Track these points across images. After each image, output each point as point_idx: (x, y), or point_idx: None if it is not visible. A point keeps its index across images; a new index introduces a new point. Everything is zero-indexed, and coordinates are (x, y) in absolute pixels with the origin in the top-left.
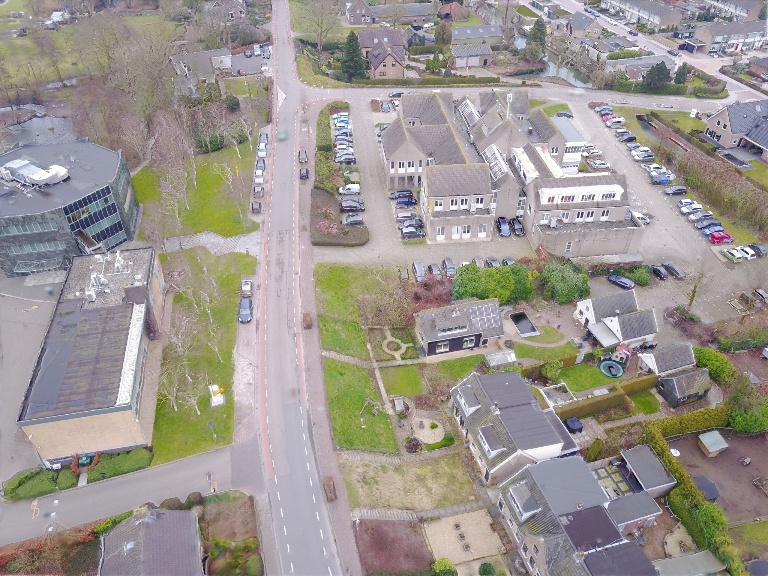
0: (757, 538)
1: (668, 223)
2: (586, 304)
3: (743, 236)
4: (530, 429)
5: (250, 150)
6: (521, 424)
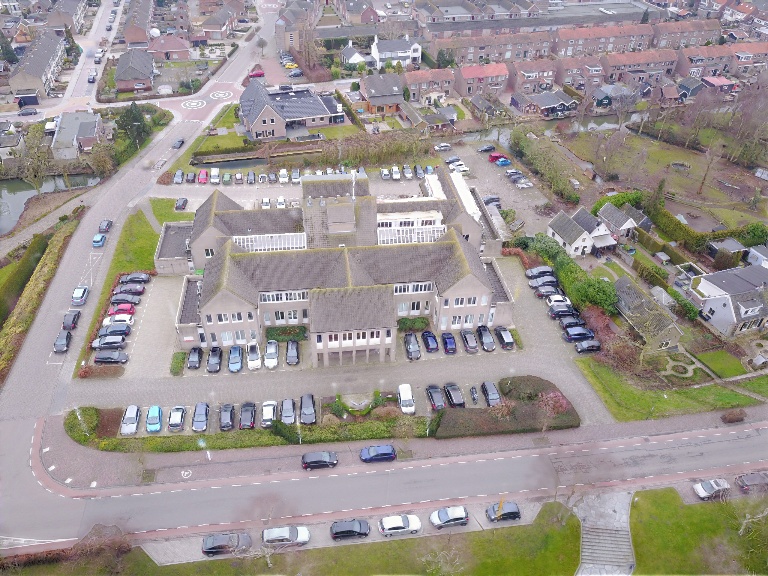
0: (734, 226)
1: (414, 190)
2: (583, 238)
3: (432, 162)
4: (763, 276)
5: (266, 570)
6: (762, 279)
